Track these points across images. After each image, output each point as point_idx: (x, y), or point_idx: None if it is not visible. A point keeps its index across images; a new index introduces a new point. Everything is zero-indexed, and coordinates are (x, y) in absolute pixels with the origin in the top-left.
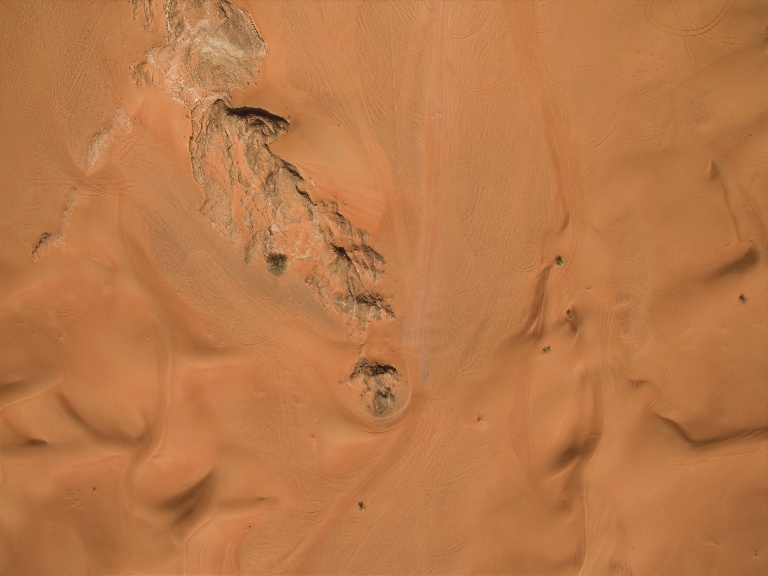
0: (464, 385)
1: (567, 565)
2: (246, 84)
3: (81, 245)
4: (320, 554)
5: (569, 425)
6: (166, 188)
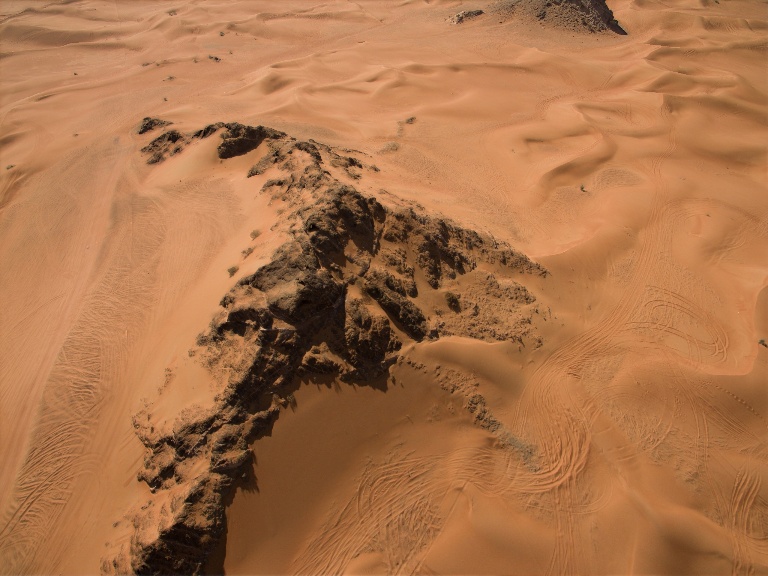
0: (87, 143)
1: (24, 109)
2: None
3: None
4: (193, 89)
5: (4, 152)
6: (330, 144)
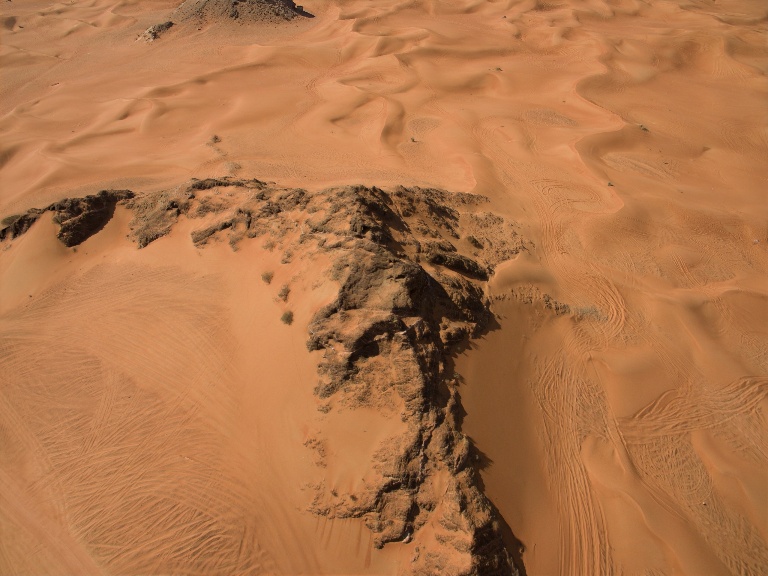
0: None
1: None
2: (134, 227)
3: (192, 151)
4: None
5: None
6: None
